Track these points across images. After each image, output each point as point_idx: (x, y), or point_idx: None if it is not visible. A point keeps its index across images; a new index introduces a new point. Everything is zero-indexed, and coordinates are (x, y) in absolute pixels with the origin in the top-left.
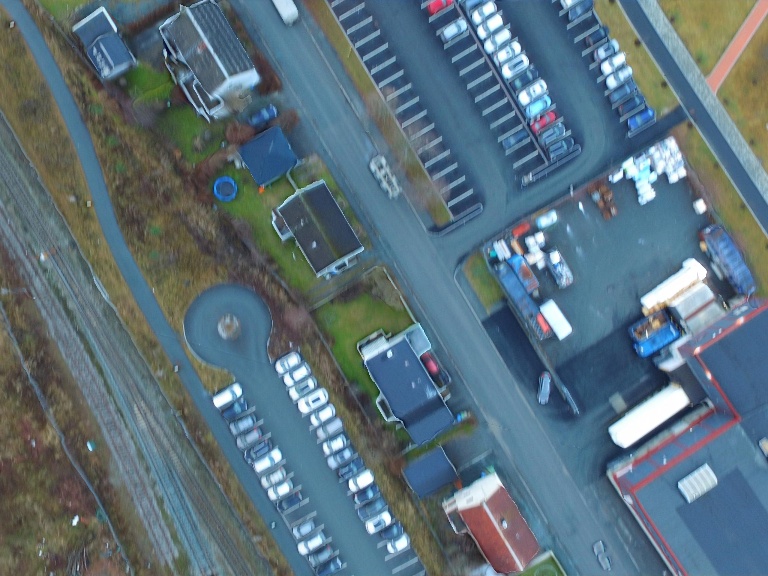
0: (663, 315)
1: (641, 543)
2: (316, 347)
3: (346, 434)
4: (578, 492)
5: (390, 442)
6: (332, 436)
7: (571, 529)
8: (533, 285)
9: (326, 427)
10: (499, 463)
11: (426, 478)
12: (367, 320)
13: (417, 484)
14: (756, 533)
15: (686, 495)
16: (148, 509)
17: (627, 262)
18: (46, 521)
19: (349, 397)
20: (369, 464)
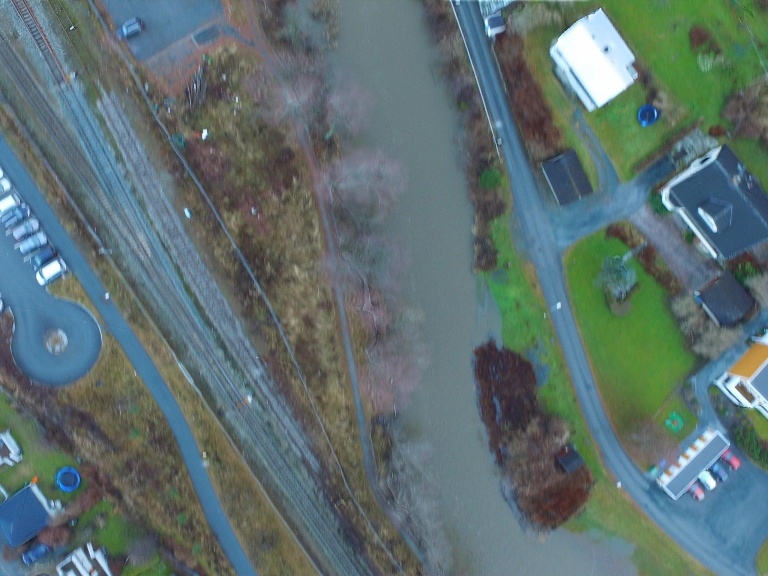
0: None
1: None
2: None
3: None
4: None
5: None
6: None
7: None
8: None
9: None
10: None
11: None
12: None
13: None
14: None
15: None
16: (132, 149)
17: None
18: (233, 133)
19: None
20: None
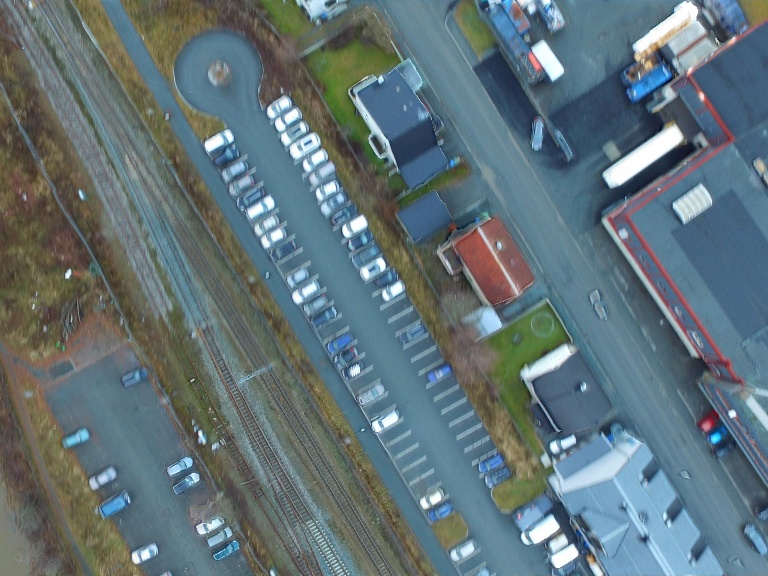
0: (655, 56)
1: (637, 292)
2: (307, 93)
3: (339, 180)
4: (573, 240)
5: (383, 186)
6: (325, 182)
7: (567, 278)
8: (524, 25)
9: (319, 171)
10: (493, 211)
11: (420, 218)
12: (358, 67)
13: (411, 224)
14: (752, 255)
15: (681, 215)
16: (141, 262)
17: (618, 9)
18: (39, 273)
19: (341, 142)
20: (363, 210)
